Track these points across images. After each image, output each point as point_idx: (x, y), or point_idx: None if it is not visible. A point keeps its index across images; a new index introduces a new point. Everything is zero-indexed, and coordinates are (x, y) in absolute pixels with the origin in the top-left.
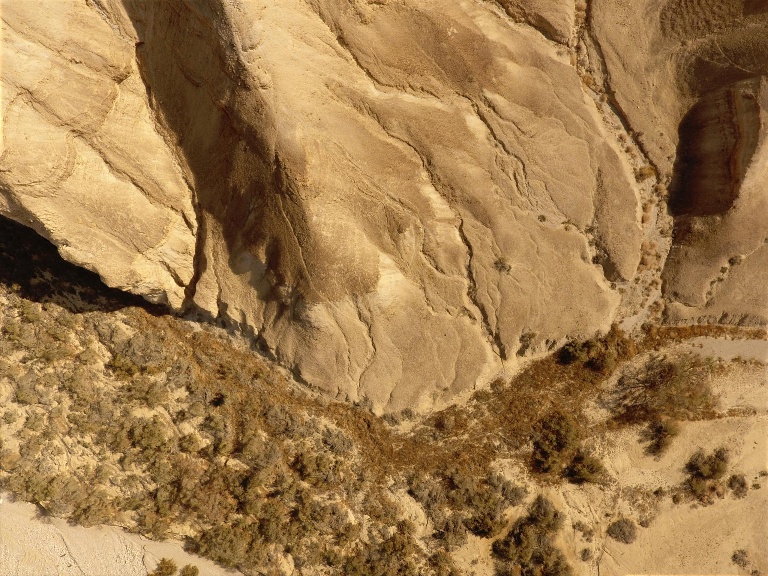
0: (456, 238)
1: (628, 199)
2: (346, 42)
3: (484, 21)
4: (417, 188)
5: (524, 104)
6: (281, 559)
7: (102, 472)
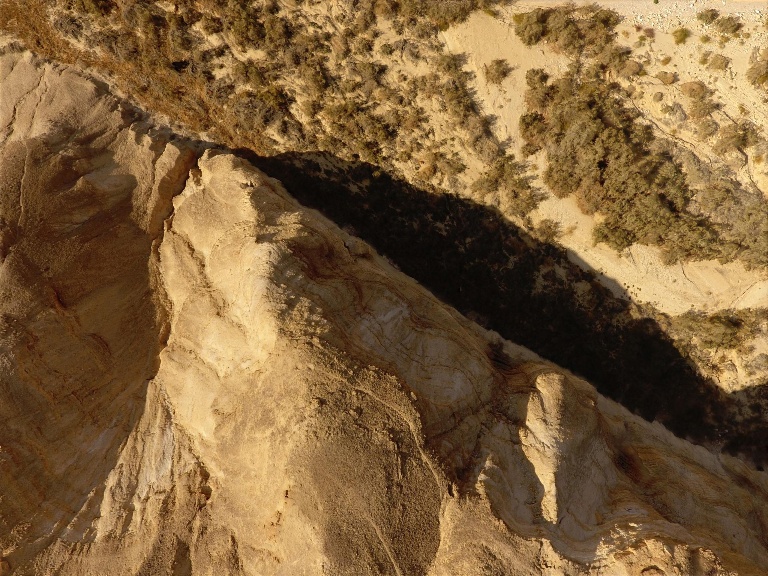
0: None
1: None
2: None
3: None
4: None
5: None
6: None
7: None
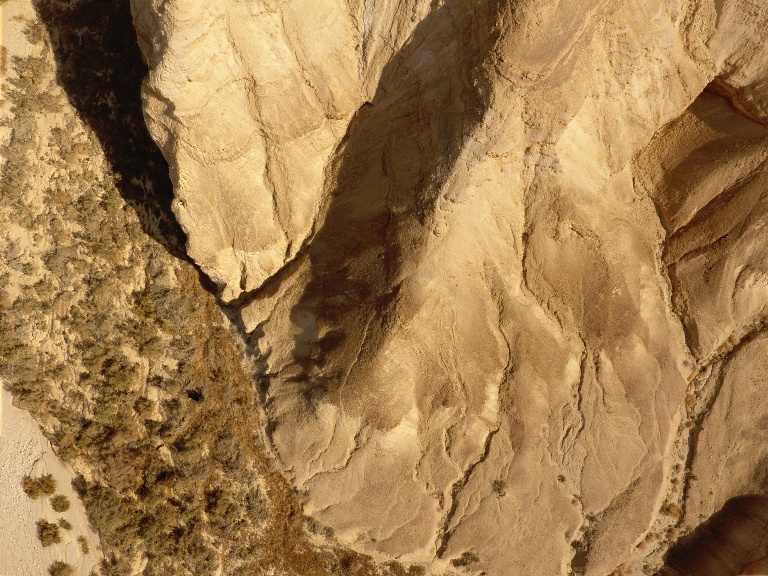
0: (482, 439)
1: (641, 522)
2: (528, 241)
3: (649, 295)
4: (485, 383)
5: (624, 382)
6: (138, 557)
7: (62, 372)
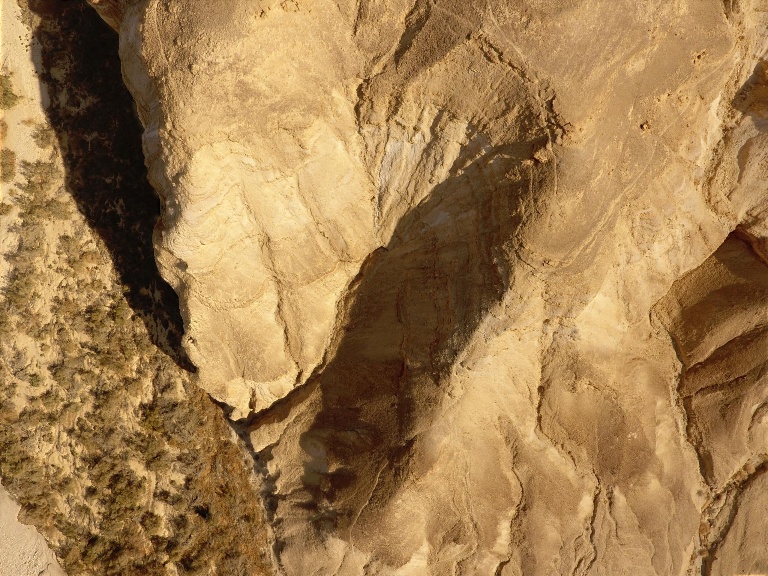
0: (493, 569)
1: None
2: (544, 394)
3: (664, 429)
4: (498, 521)
5: (637, 514)
6: None
7: (68, 486)
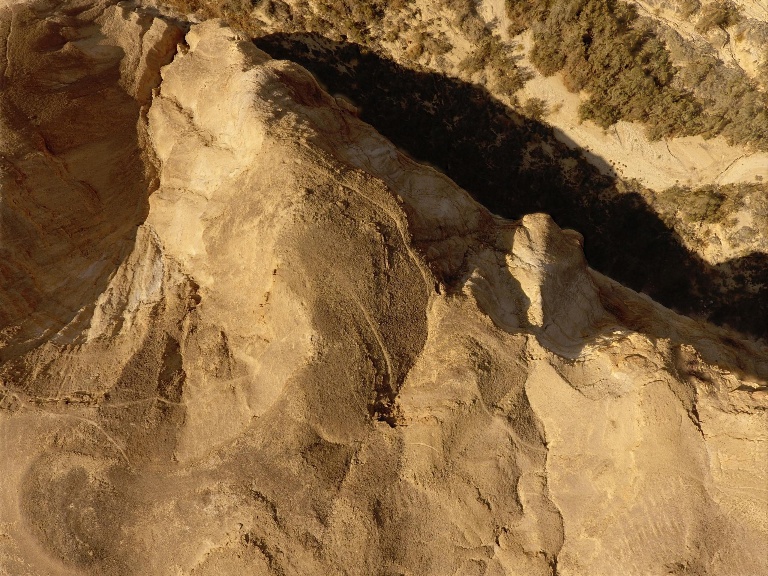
0: None
1: None
2: None
3: None
4: None
5: None
6: None
7: None
